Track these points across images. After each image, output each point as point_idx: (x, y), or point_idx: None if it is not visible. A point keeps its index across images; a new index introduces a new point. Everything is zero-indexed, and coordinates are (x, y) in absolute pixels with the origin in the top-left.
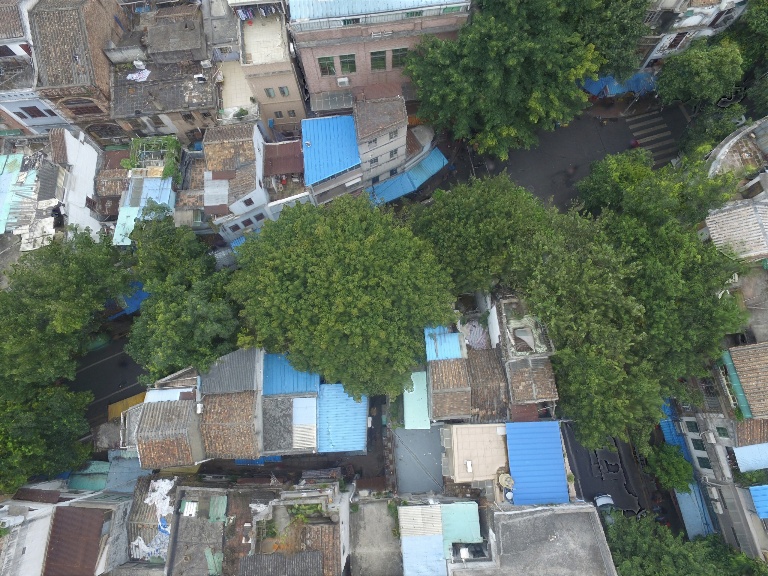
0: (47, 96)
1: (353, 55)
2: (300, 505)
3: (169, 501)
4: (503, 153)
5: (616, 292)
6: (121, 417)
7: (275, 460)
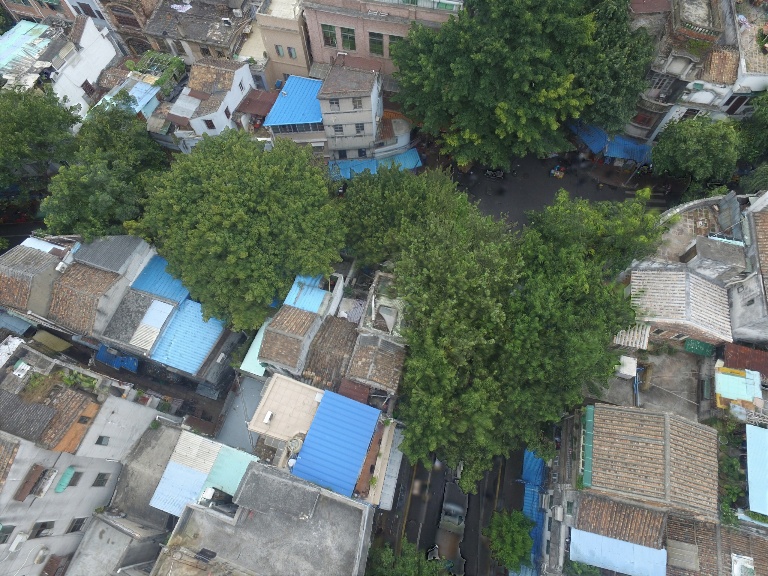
0: None
1: (353, 30)
2: (79, 373)
3: None
4: (461, 158)
5: (485, 292)
6: None
7: (131, 369)
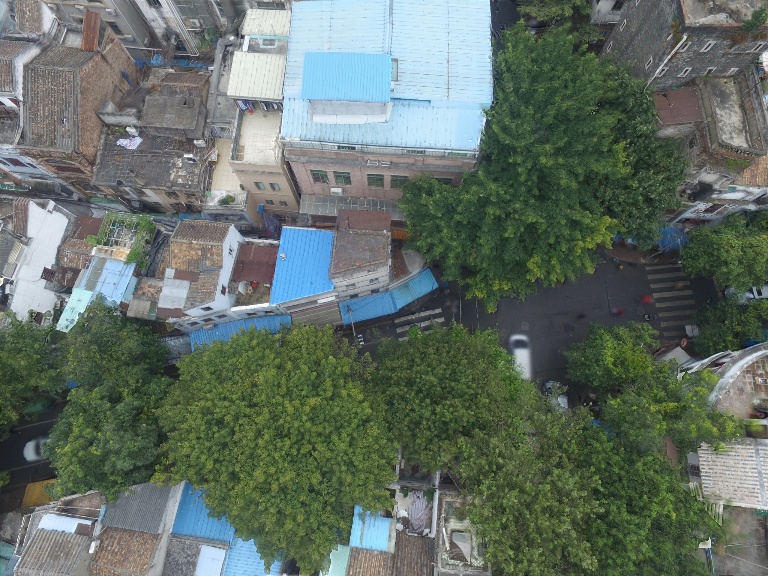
0: (27, 154)
1: (348, 172)
2: None
3: None
4: (491, 306)
5: None
6: None
7: None
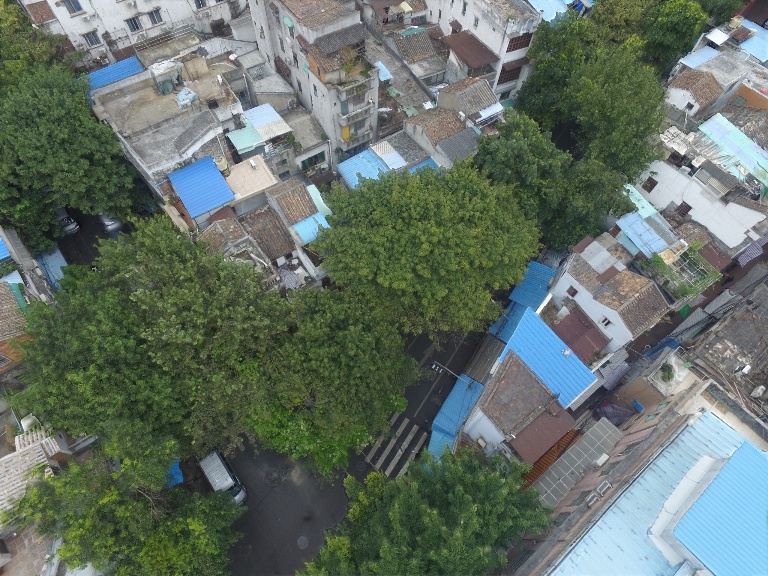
0: None
1: None
2: (355, 83)
3: None
4: (352, 481)
5: None
6: None
7: None
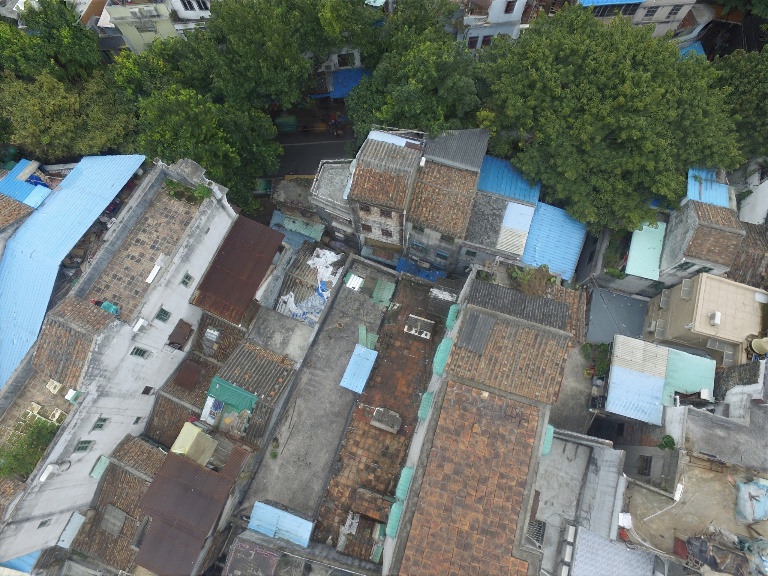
0: None
1: None
2: None
3: (332, 270)
4: None
5: None
6: (320, 164)
7: None
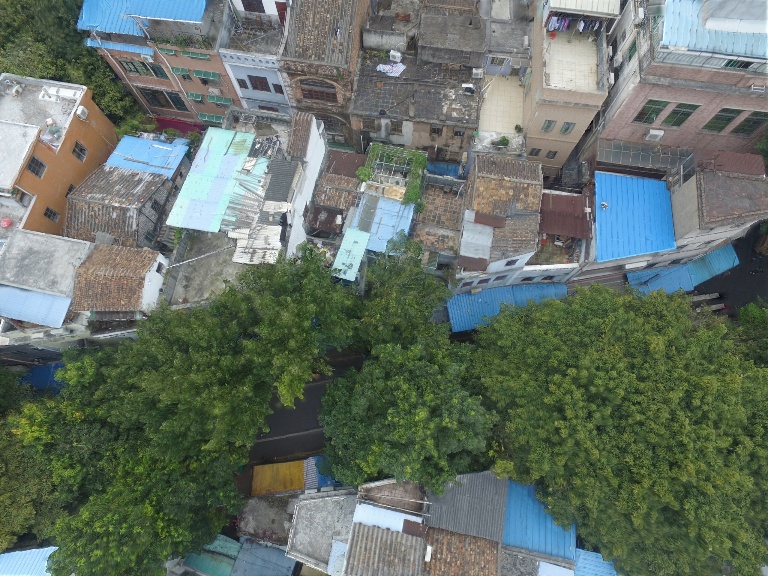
0: (288, 69)
1: (697, 106)
2: None
3: None
4: None
5: None
6: None
7: None
